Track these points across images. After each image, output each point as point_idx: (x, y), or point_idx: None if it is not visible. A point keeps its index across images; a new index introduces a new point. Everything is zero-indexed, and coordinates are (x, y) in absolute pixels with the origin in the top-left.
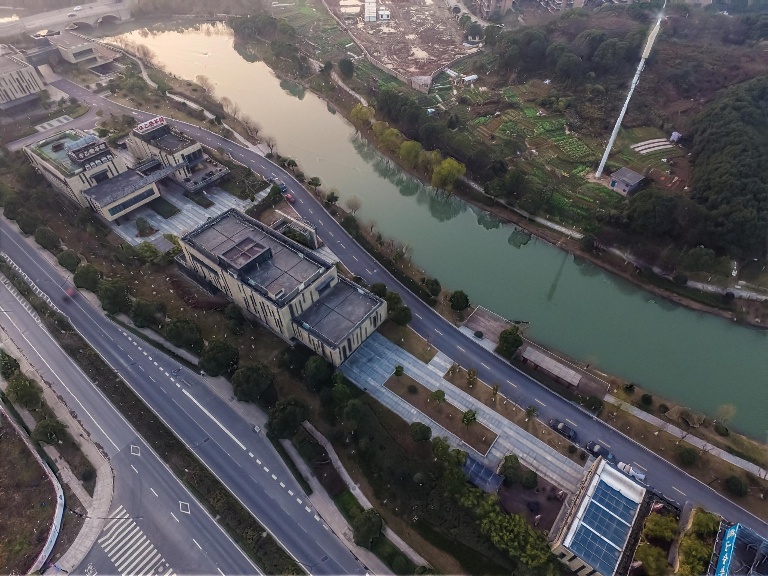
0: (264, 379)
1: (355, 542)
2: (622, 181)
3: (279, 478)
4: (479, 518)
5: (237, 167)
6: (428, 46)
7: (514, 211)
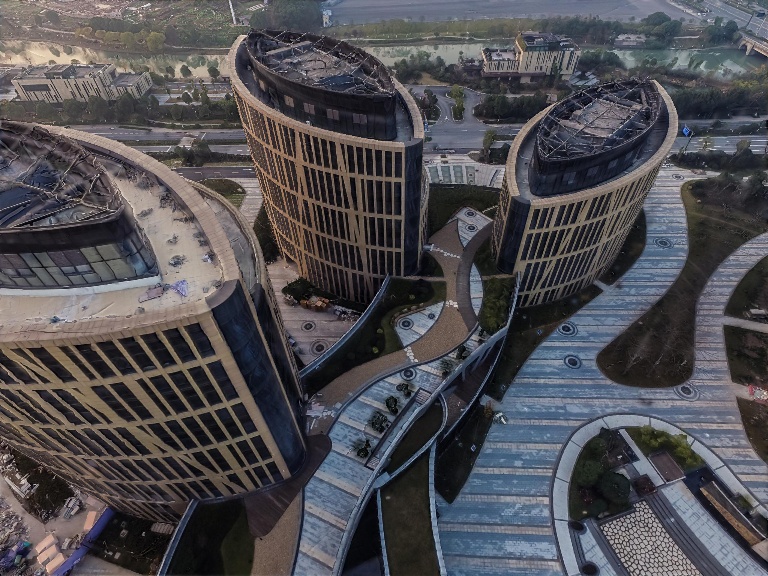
0: (104, 100)
1: (174, 117)
2: (245, 19)
3: (134, 132)
4: (220, 106)
5: (11, 75)
6: (107, 2)
7: (201, 49)
